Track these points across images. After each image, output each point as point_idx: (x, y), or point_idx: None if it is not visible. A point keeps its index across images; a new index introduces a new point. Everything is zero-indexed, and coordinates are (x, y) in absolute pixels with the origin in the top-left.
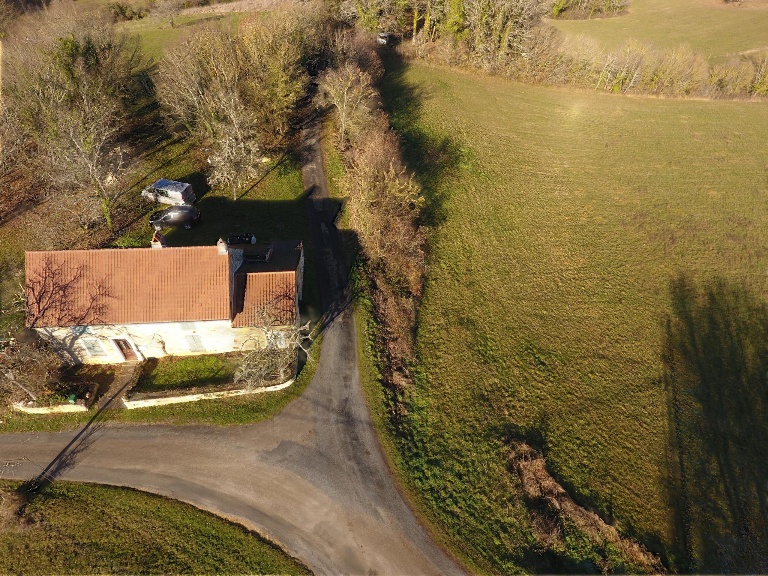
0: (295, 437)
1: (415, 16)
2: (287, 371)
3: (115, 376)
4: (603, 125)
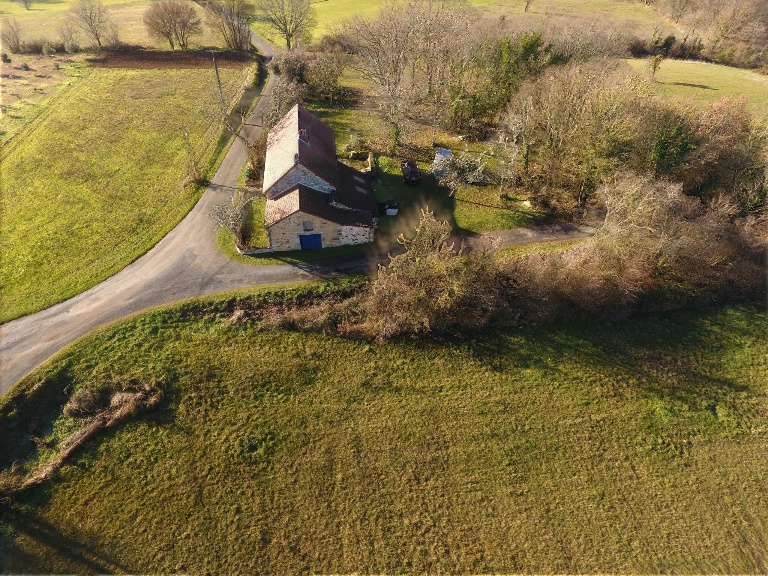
0: (198, 260)
1: None
2: (246, 246)
3: None
4: None
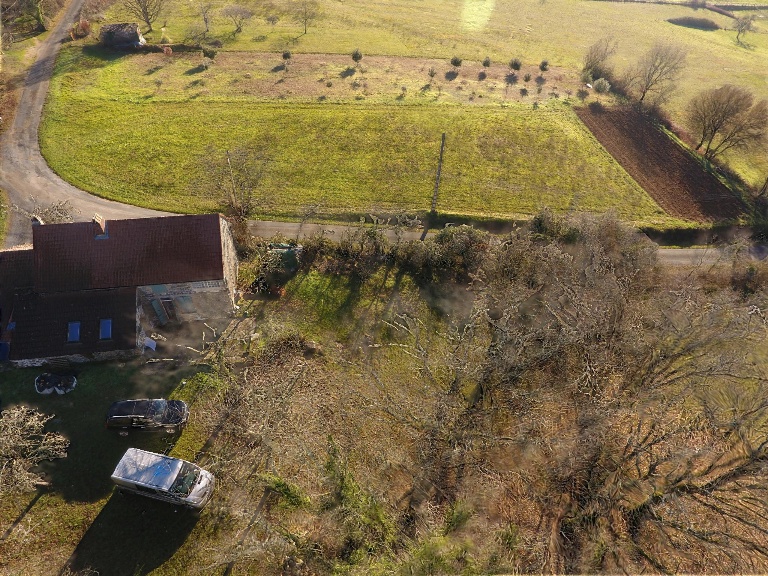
0: None
1: None
2: None
3: None
4: None
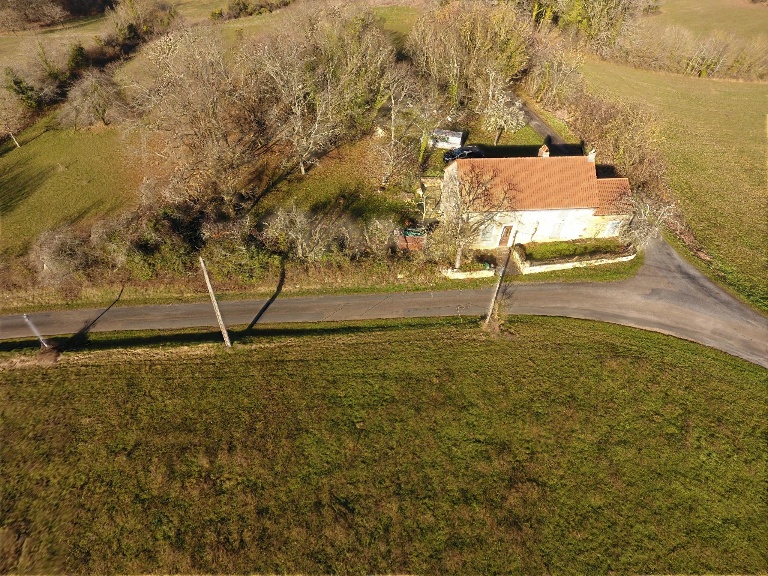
0: (660, 286)
1: (535, 9)
2: None
3: (495, 257)
4: (711, 101)
